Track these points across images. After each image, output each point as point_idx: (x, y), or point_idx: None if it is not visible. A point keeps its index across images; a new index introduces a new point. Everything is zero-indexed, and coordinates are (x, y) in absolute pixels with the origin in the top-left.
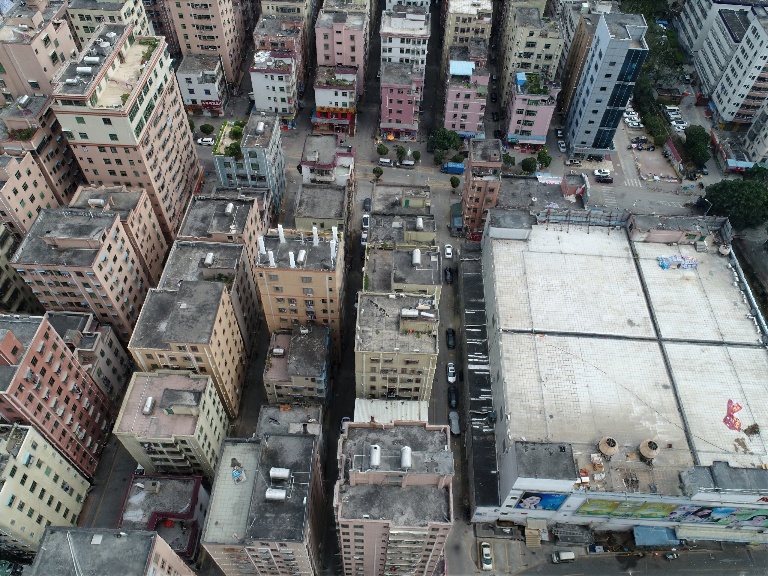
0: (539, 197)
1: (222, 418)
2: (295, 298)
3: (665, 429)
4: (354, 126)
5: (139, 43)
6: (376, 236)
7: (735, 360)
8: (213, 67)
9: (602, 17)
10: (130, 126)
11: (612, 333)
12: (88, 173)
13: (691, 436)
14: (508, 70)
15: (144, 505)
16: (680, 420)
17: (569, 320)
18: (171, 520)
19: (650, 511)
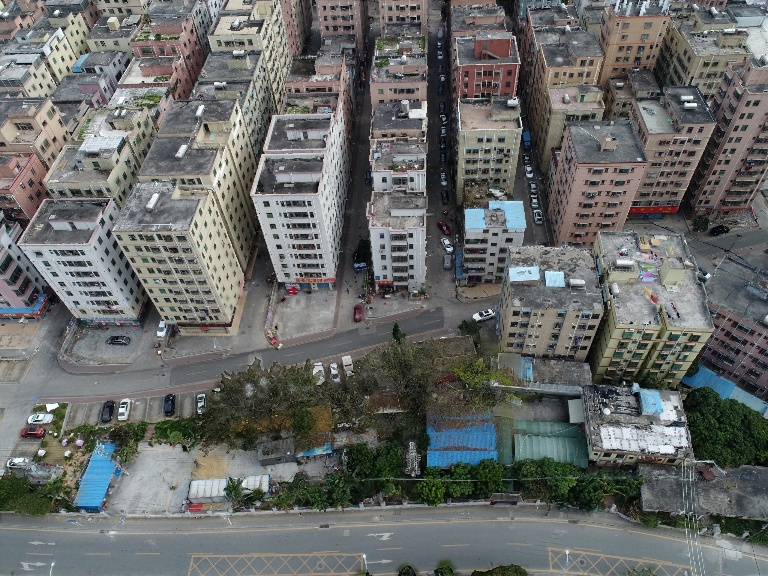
0: None
1: None
2: (632, 45)
3: None
4: None
5: None
6: None
7: None
8: None
9: None
10: None
11: None
12: None
13: None
14: None
15: None
16: None
17: None
18: None
19: None
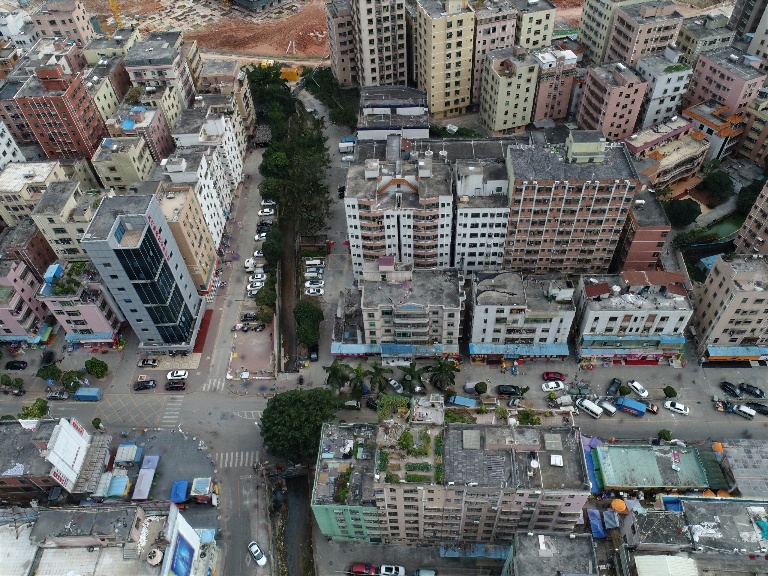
0: (7, 455)
1: None
2: None
3: None
4: None
5: None
6: None
7: None
8: None
9: (101, 204)
10: None
11: None
12: None
13: None
14: None
15: None
16: None
17: None
18: None
19: None
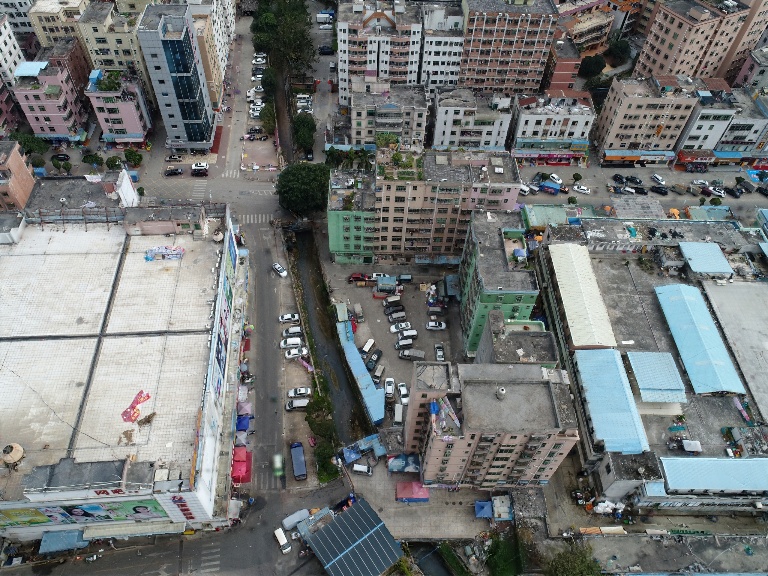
0: (79, 197)
1: None
2: None
3: (53, 429)
4: None
5: None
6: None
7: (170, 349)
8: None
9: None
10: None
11: (52, 333)
12: None
13: (78, 434)
14: None
15: None
16: (75, 418)
17: (12, 324)
18: None
19: (25, 517)
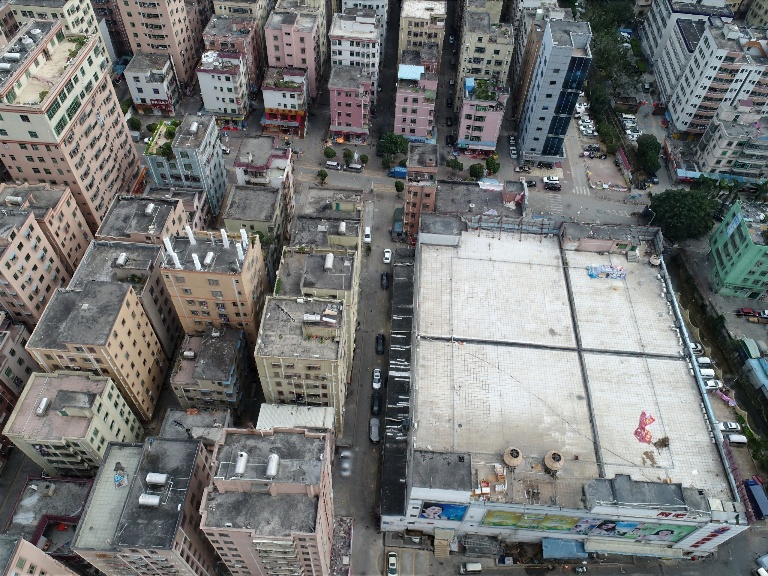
0: (479, 203)
1: (129, 421)
2: (205, 300)
3: (574, 440)
4: (304, 128)
5: (68, 40)
6: (300, 239)
7: (653, 372)
8: (162, 66)
9: (548, 24)
10: (49, 124)
11: (532, 342)
12: (12, 170)
13: (600, 448)
14: (459, 75)
15: (36, 508)
16: (590, 432)
17: (490, 328)
18: (64, 523)
19: (554, 523)
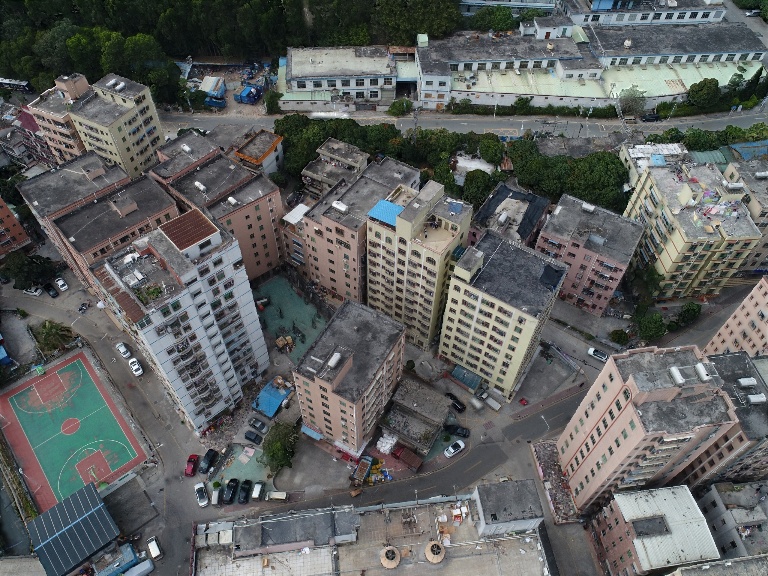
0: None
1: None
2: None
3: None
4: None
5: None
6: None
7: None
8: None
9: None
10: None
11: None
12: None
13: None
14: None
15: None
16: None
17: None
18: None
19: None
